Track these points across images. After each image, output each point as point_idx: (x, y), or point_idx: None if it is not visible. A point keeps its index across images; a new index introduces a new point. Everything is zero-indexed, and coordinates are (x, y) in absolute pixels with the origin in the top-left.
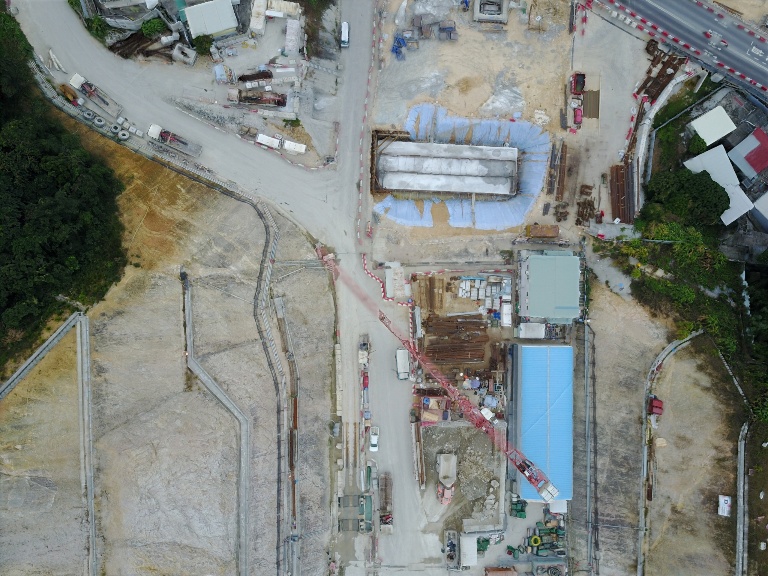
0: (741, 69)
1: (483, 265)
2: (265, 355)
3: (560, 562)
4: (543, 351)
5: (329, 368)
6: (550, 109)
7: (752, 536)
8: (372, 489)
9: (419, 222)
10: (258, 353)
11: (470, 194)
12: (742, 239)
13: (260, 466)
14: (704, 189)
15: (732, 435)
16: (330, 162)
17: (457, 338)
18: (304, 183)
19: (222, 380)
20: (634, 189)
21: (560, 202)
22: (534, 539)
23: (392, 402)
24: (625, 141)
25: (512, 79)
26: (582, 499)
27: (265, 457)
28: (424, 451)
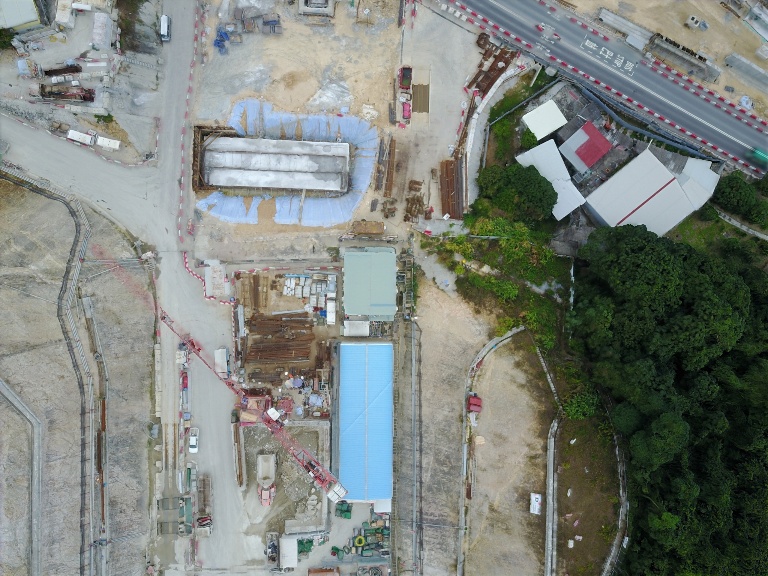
0: (575, 63)
1: (309, 262)
2: (70, 356)
3: (383, 562)
4: (361, 349)
5: (148, 368)
6: (378, 104)
7: (560, 534)
8: (192, 491)
9: (243, 219)
10: (62, 354)
11: (301, 190)
12: (572, 234)
13: (57, 470)
14: (528, 184)
15: (542, 432)
16: (149, 158)
17: (282, 337)
18: (122, 180)
19: (16, 382)
20: (462, 184)
21: (388, 198)
22: (359, 539)
23: (214, 402)
24: (455, 136)
25: (339, 73)
26: (408, 498)
27: (64, 460)
28: (245, 452)
